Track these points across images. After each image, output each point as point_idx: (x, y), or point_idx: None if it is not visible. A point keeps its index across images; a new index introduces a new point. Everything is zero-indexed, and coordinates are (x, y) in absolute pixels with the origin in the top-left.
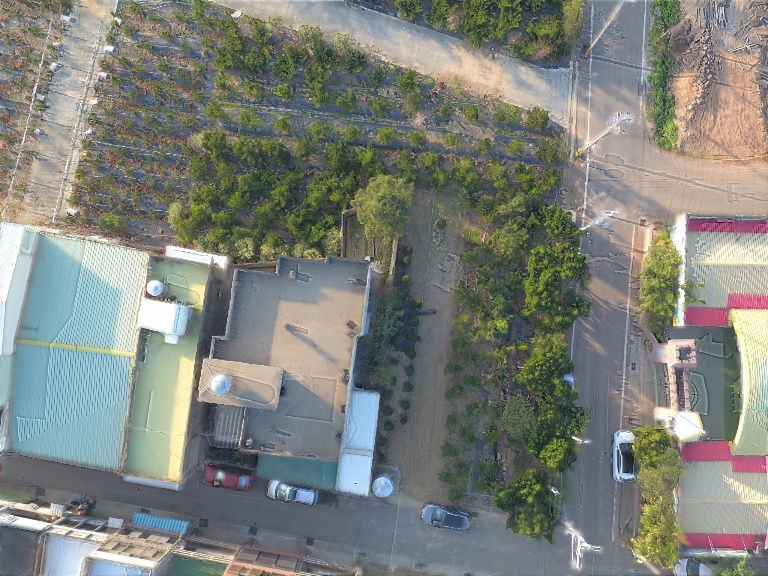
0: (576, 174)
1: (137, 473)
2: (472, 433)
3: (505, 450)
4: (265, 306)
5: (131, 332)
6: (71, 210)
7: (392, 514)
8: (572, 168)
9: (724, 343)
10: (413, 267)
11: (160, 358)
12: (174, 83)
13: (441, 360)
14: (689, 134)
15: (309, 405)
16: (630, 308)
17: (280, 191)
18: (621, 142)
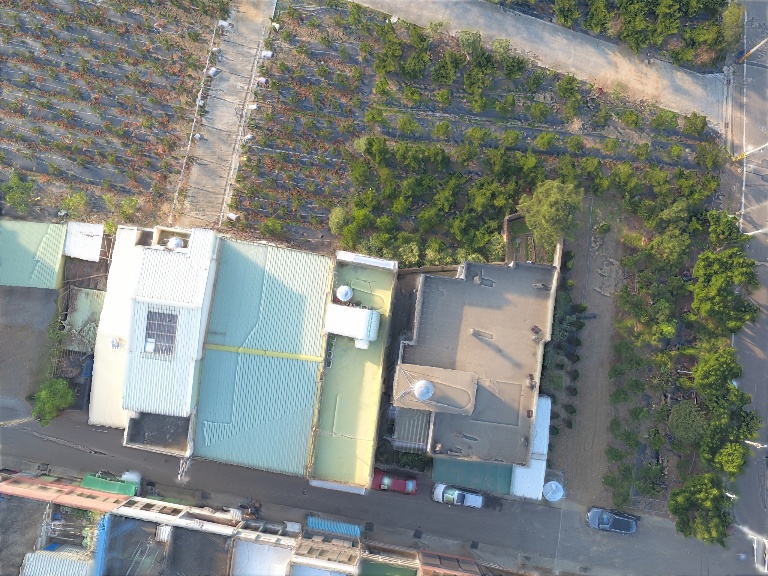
0: (733, 179)
1: (324, 477)
2: (637, 437)
3: (667, 454)
4: (450, 311)
5: (318, 337)
6: (232, 215)
7: (556, 517)
8: (729, 173)
9: None
10: (573, 272)
11: (345, 363)
12: (332, 88)
13: (602, 364)
14: None
15: (495, 410)
16: None
17: (445, 196)
18: None
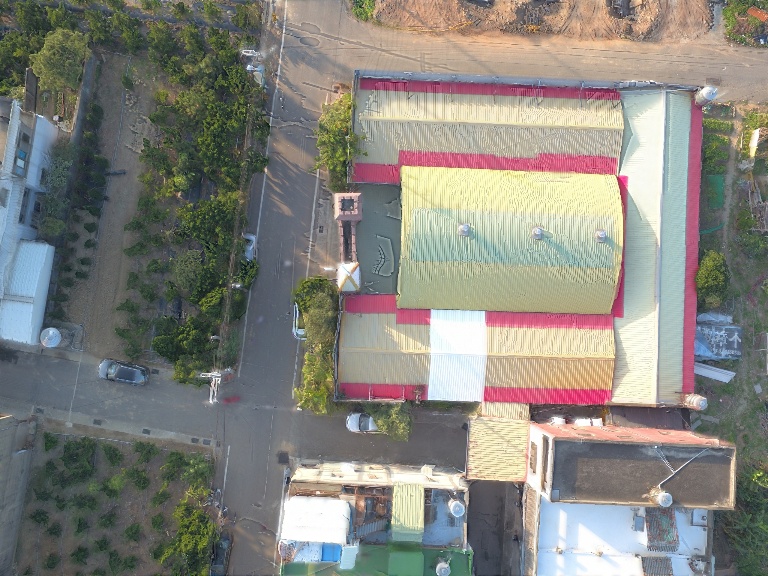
0: (272, 41)
1: None
2: (152, 289)
3: (190, 309)
4: None
5: None
6: None
7: (73, 370)
8: (269, 35)
9: None
10: (104, 128)
11: None
12: None
13: (129, 220)
14: (385, 4)
15: None
16: (320, 172)
17: None
18: (318, 11)
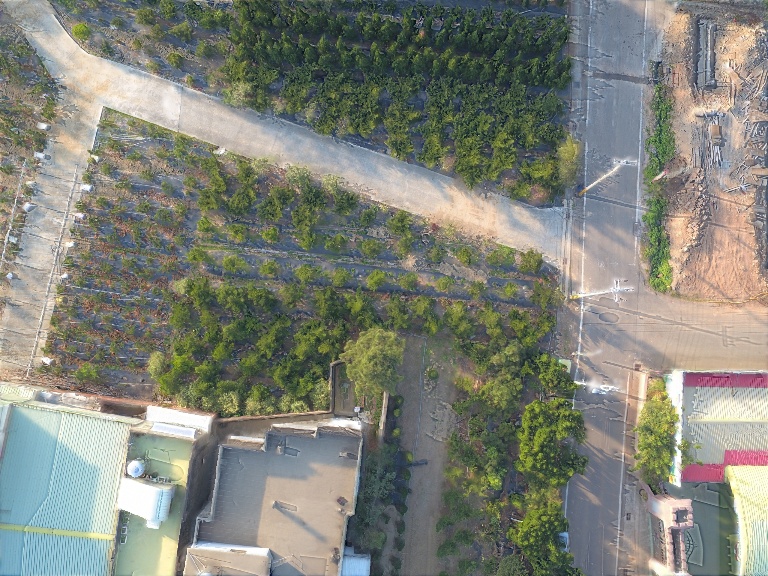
0: (570, 318)
1: None
2: None
3: None
4: (252, 482)
5: (111, 512)
6: (46, 359)
7: None
8: (566, 311)
9: (719, 493)
10: (404, 416)
11: (141, 537)
12: (155, 223)
13: (433, 513)
14: (684, 276)
15: None
16: (625, 456)
17: (266, 343)
18: None
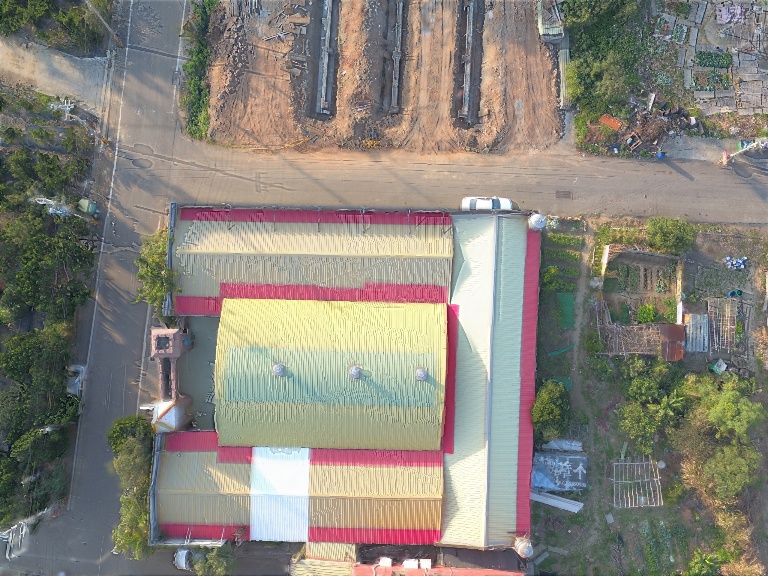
0: (105, 164)
1: None
2: None
3: None
4: None
5: None
6: None
7: None
8: (101, 158)
9: None
10: None
11: None
12: None
13: None
14: (219, 123)
15: None
16: None
17: None
18: (151, 131)
